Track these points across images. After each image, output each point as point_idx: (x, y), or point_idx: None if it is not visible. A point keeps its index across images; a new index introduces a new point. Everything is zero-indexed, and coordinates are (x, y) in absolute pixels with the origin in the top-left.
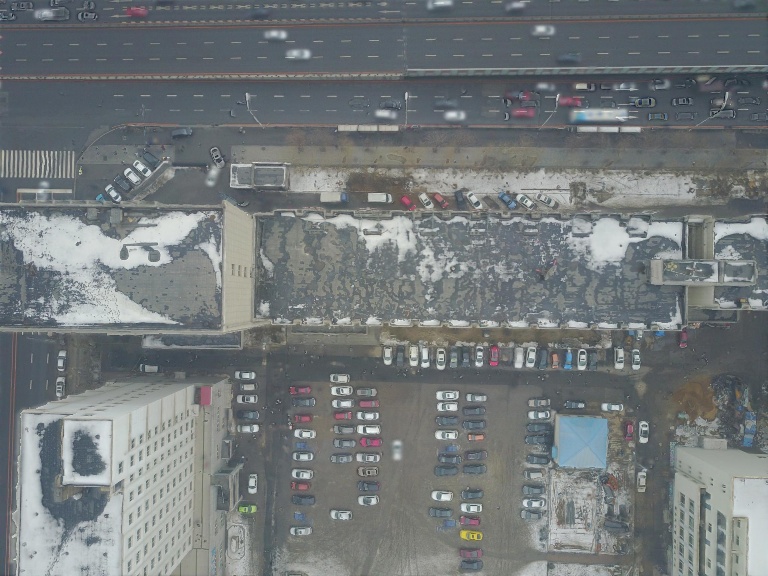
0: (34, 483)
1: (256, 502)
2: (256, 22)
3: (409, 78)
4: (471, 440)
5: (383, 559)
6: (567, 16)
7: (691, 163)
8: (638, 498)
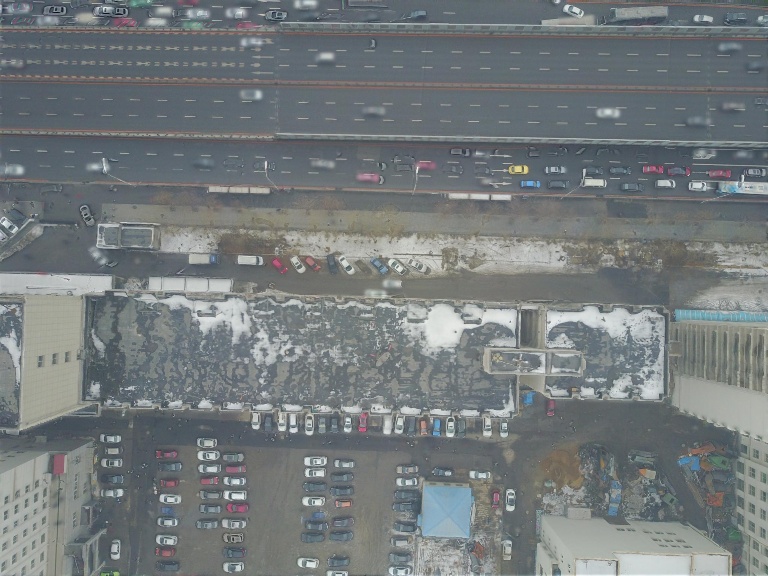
0: None
1: (119, 568)
2: (128, 79)
3: (283, 140)
4: (338, 507)
5: None
6: (439, 83)
7: (563, 231)
8: (504, 566)
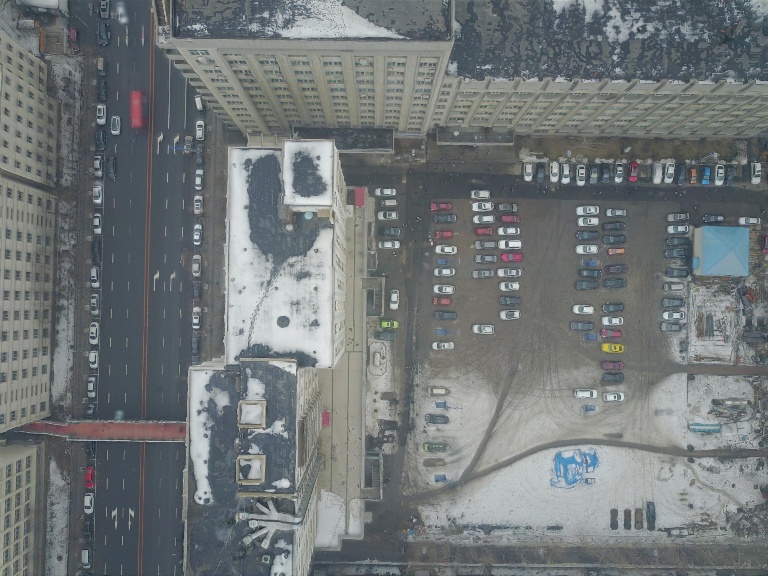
0: (242, 218)
1: (397, 319)
2: None
3: None
4: (612, 254)
5: (525, 373)
6: None
7: None
8: None
